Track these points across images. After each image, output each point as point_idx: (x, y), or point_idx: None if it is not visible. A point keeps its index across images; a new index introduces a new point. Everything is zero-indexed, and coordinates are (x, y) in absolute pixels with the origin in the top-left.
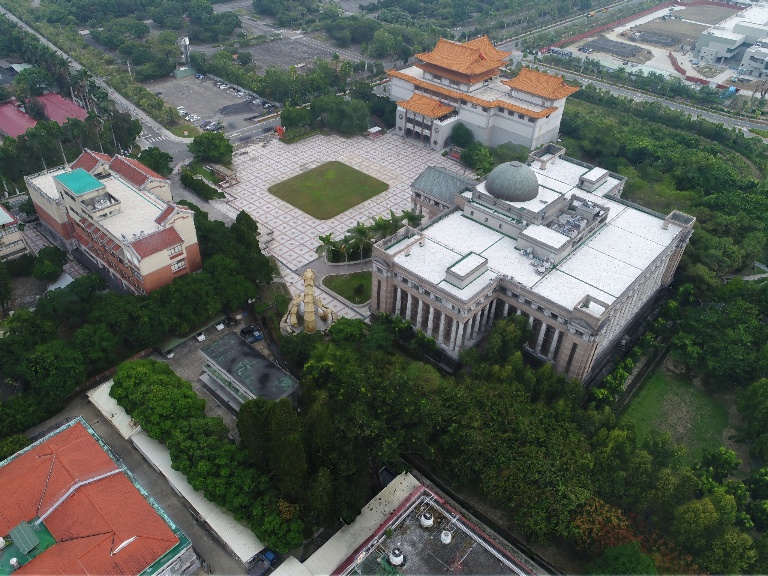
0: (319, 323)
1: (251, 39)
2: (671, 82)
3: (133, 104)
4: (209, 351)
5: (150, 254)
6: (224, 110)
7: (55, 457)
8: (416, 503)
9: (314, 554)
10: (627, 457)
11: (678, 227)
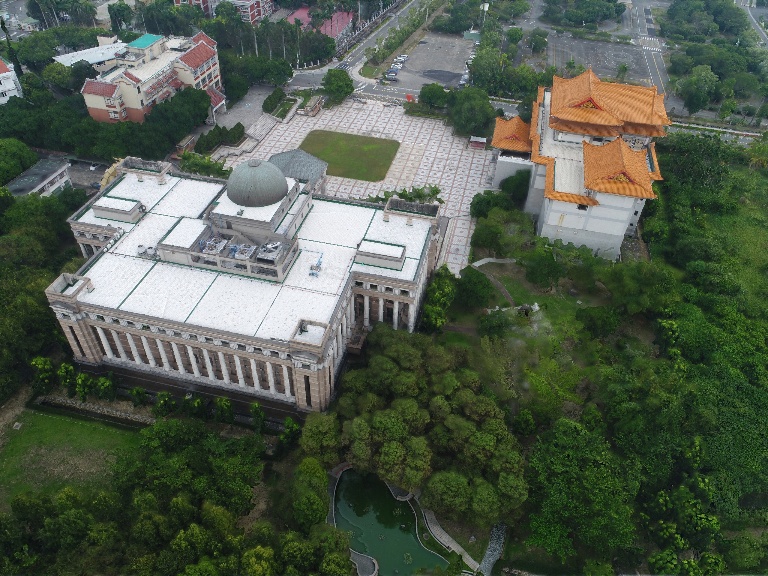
0: None
1: None
2: None
3: None
4: (43, 163)
5: (89, 93)
6: (431, 72)
7: None
8: None
9: None
10: None
11: None
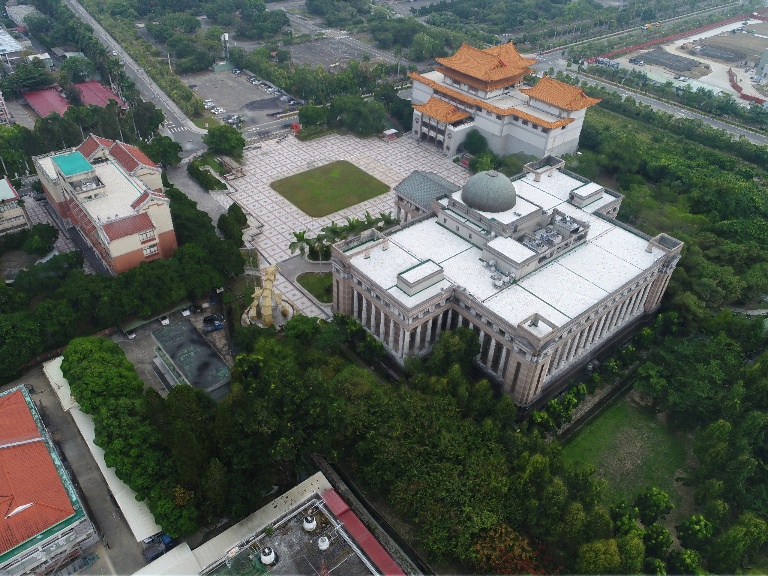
0: (279, 318)
1: (296, 37)
2: (718, 99)
3: (166, 95)
4: (160, 335)
5: (119, 237)
6: (250, 105)
7: None
8: (306, 505)
9: (206, 543)
10: (545, 486)
11: None
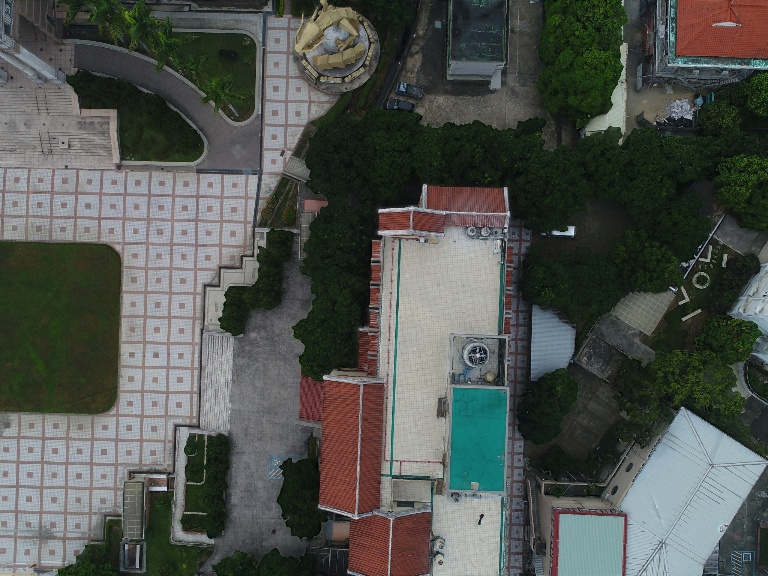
0: None
1: None
2: None
3: None
4: (496, 53)
5: (487, 189)
6: None
7: (732, 1)
8: None
9: None
10: None
11: None
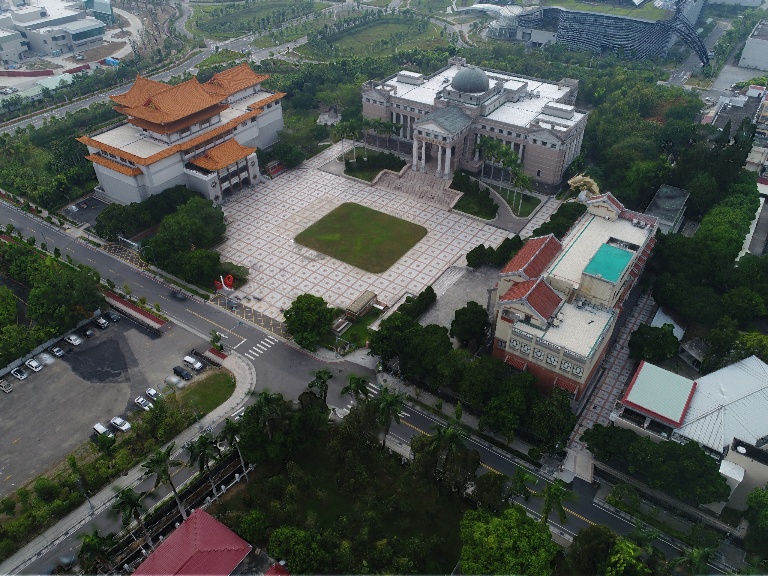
0: None
1: None
2: (114, 69)
3: (51, 526)
4: (670, 220)
5: None
6: (105, 374)
7: None
8: None
9: None
10: None
11: (455, 66)
